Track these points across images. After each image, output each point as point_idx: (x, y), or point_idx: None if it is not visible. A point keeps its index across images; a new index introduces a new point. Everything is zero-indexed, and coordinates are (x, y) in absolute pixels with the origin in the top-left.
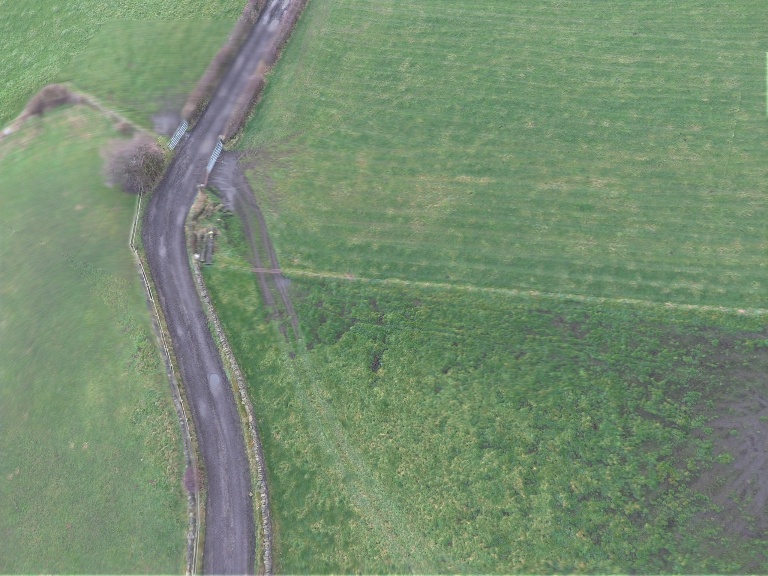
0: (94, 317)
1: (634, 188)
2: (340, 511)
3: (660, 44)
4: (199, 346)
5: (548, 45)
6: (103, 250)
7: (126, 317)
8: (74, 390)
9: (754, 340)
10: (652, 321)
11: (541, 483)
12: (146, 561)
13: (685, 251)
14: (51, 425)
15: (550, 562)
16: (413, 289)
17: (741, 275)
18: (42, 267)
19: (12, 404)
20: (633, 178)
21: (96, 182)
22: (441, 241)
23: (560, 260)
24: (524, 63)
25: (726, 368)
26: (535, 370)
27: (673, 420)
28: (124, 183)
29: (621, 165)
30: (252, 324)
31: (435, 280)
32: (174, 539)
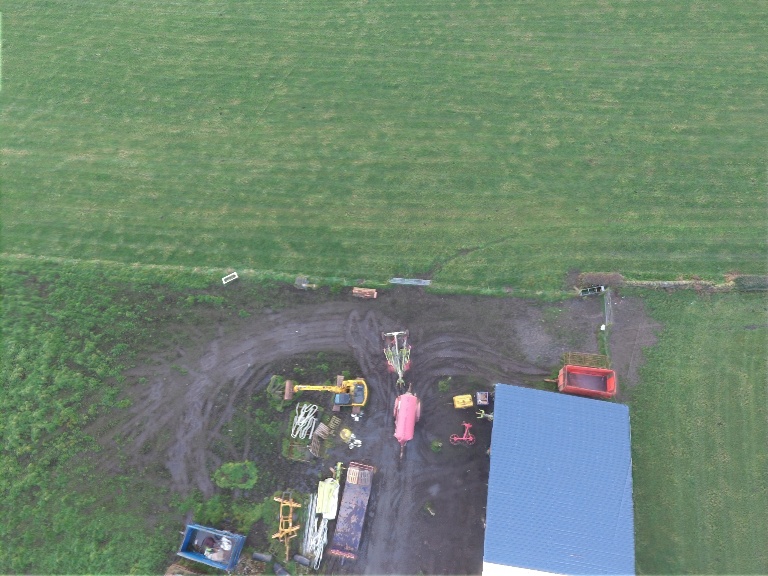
0: None
1: (155, 158)
2: None
3: (241, 25)
4: None
5: (134, 26)
6: None
7: None
8: None
9: (196, 296)
10: (113, 280)
11: None
12: None
13: (175, 216)
14: None
15: None
16: None
17: (213, 237)
18: None
19: None
20: (158, 149)
21: None
22: None
23: (58, 225)
24: (105, 43)
25: (161, 322)
26: None
27: (94, 370)
28: None
29: (152, 137)
30: None
31: None
32: None
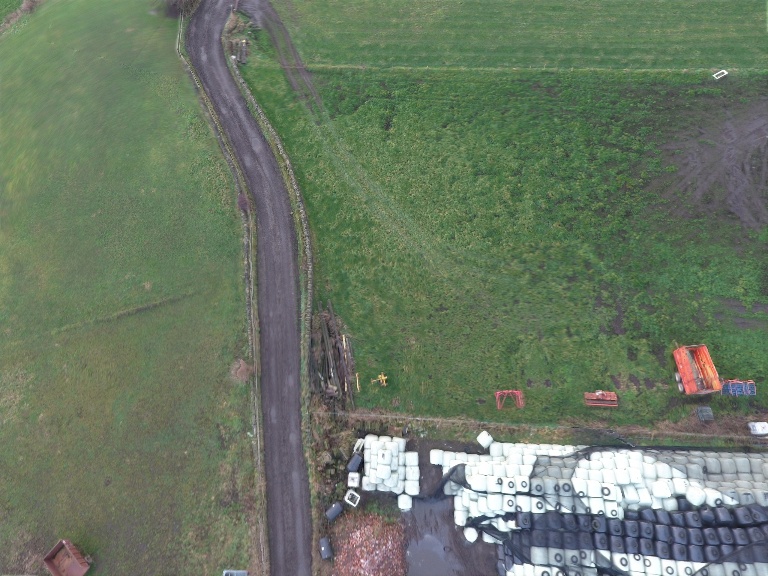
0: (151, 105)
1: None
2: (364, 222)
3: None
4: (241, 120)
5: None
6: (153, 59)
7: (178, 103)
8: (140, 155)
9: (695, 89)
10: (612, 81)
11: (525, 194)
12: (211, 262)
13: (640, 34)
14: (123, 179)
15: (533, 244)
16: (416, 72)
17: (685, 47)
18: (103, 74)
19: (89, 168)
20: None
21: (142, 11)
22: (437, 38)
23: (537, 45)
24: None
25: (672, 109)
26: (518, 121)
27: (630, 147)
28: (169, 3)
29: None
30: (283, 104)
31: (434, 66)
32: (232, 245)
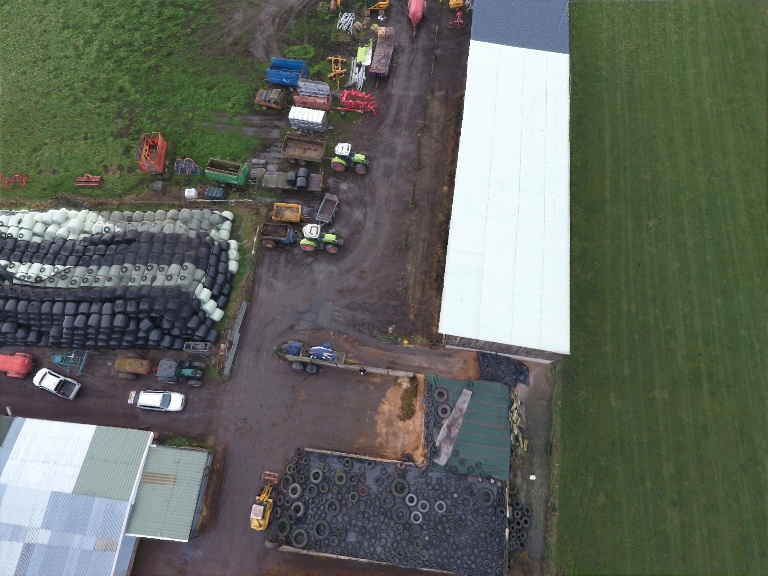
0: None
1: None
2: None
3: None
4: None
5: None
6: None
7: None
8: None
9: None
10: None
11: (95, 42)
12: None
13: None
14: None
15: (85, 76)
16: None
17: None
18: None
19: None
20: None
21: None
22: None
23: None
24: None
25: None
26: None
27: (192, 6)
28: None
29: None
30: None
31: None
32: None
